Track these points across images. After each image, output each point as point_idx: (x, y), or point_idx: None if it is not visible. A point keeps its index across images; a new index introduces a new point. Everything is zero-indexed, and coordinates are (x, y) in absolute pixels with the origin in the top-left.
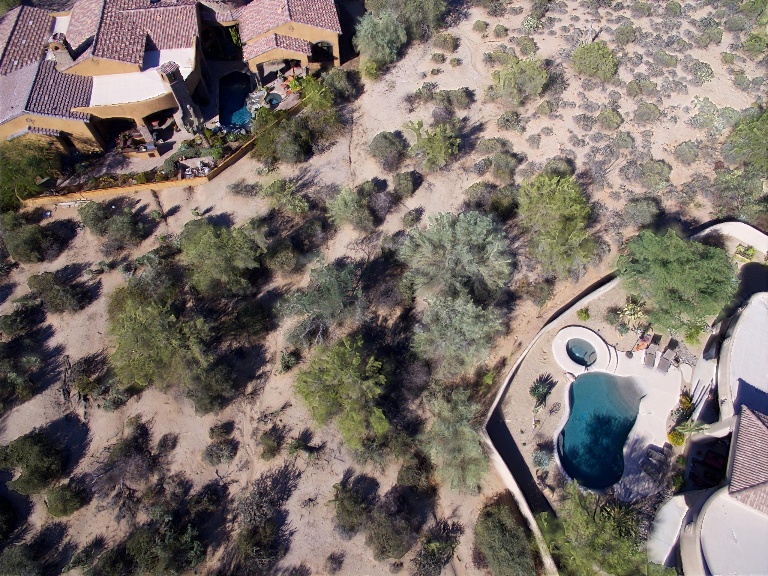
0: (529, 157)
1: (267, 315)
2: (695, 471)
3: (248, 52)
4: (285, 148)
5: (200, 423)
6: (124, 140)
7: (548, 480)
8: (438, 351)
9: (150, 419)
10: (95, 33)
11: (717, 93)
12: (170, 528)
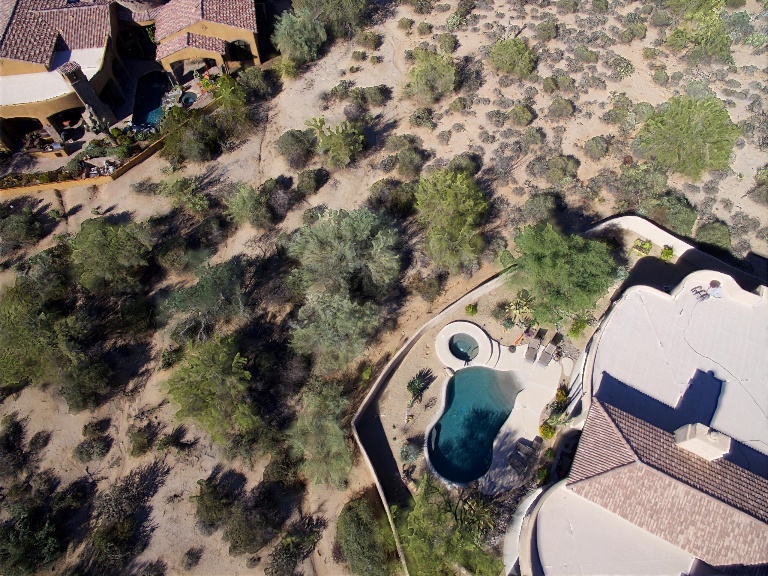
0: (437, 153)
1: (157, 313)
2: (562, 464)
3: (161, 51)
4: (190, 146)
5: (75, 421)
6: (31, 140)
7: (414, 474)
8: (317, 347)
9: (25, 417)
10: (1, 33)
11: (635, 88)
12: (25, 525)
